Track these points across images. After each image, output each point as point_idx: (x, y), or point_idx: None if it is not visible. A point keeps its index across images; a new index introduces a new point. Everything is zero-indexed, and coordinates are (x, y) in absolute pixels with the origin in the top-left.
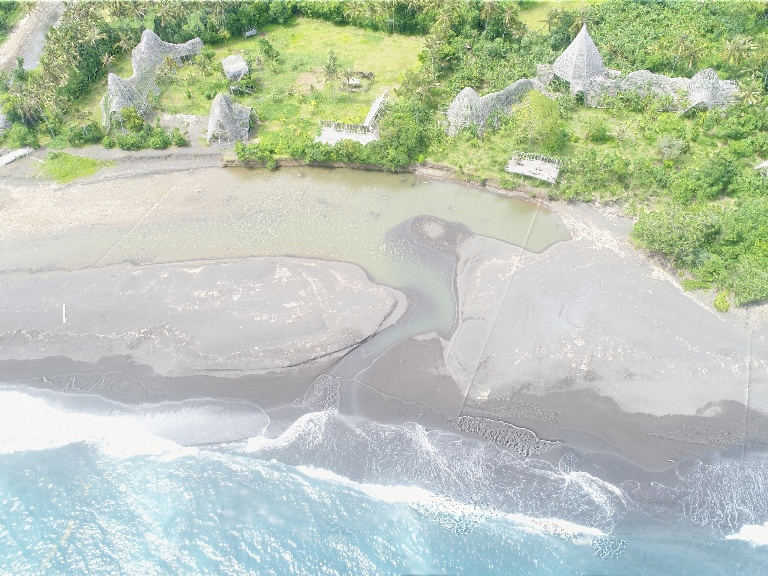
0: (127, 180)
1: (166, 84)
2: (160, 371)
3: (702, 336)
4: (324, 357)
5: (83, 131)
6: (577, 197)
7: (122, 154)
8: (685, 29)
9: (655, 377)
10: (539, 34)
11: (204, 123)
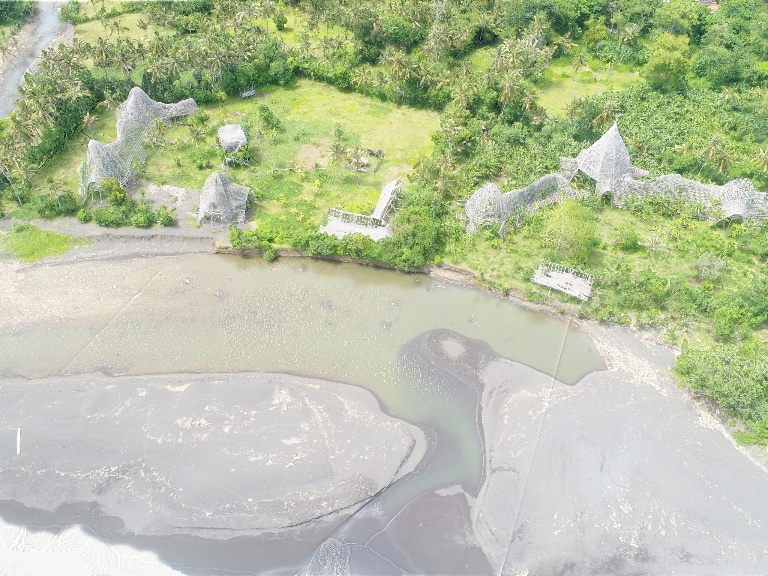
0: (103, 263)
1: (153, 147)
2: (132, 527)
3: (763, 506)
4: (331, 515)
5: (55, 202)
6: (610, 317)
7: (99, 231)
8: (708, 125)
9: (716, 560)
10: (558, 120)
11: (194, 199)
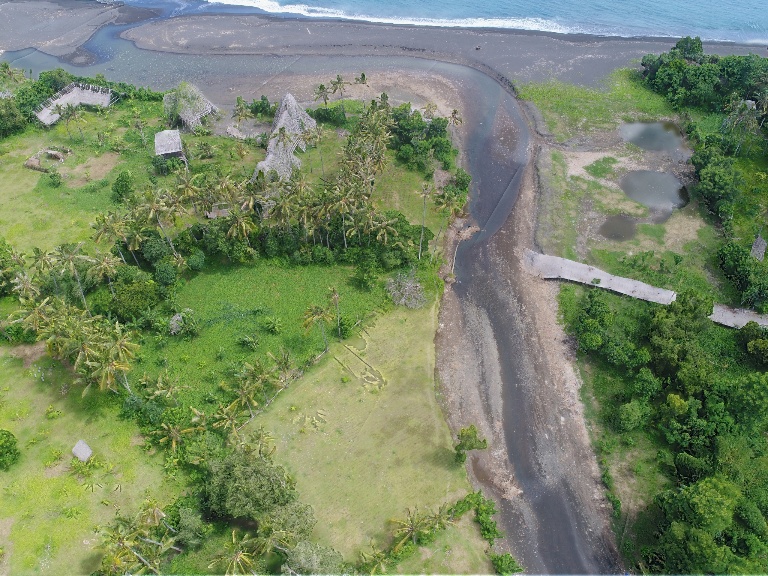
0: None
1: None
2: None
3: None
4: None
5: None
6: None
7: None
8: None
9: (33, 8)
10: None
11: (220, 127)
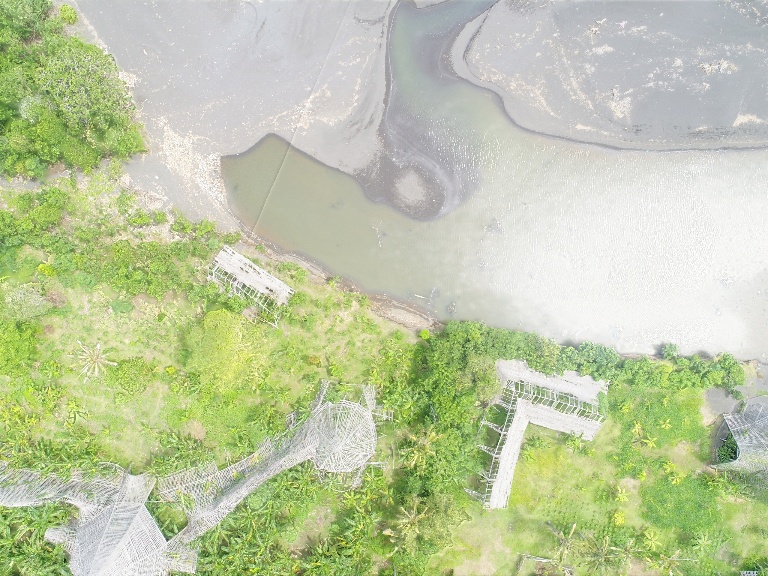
0: None
1: None
2: None
3: None
4: None
5: None
6: None
7: None
8: None
9: None
10: None
11: None
